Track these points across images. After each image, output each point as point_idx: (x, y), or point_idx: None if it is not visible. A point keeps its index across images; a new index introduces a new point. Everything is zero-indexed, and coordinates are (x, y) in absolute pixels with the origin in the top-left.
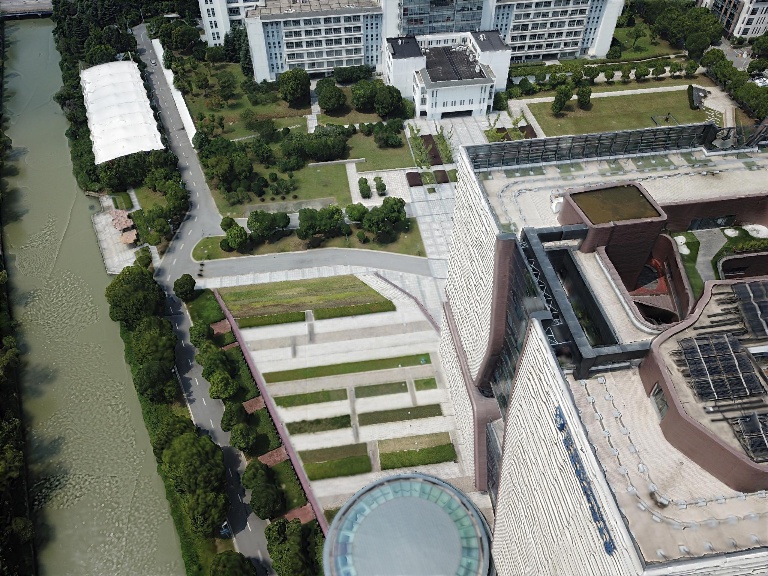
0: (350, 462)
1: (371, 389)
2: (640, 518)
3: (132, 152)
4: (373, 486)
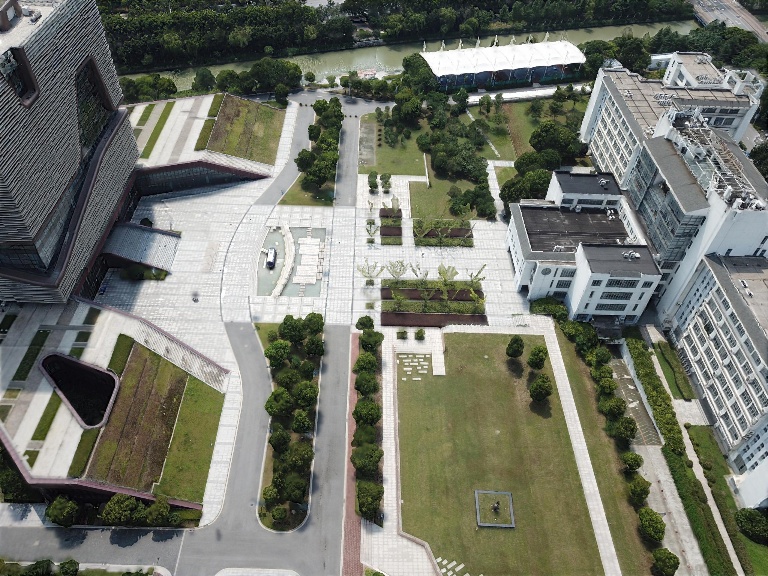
0: None
1: (136, 134)
2: None
3: (428, 61)
4: None
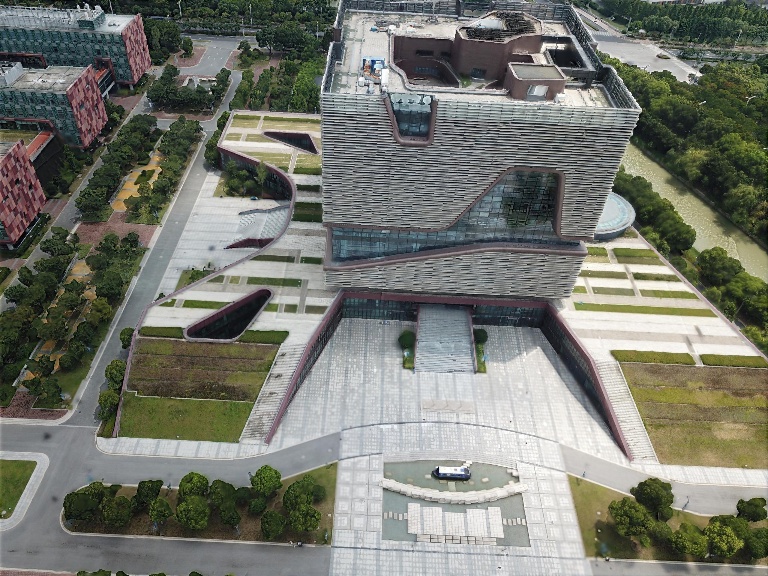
0: (628, 253)
1: (622, 292)
2: (556, 30)
3: None
4: (612, 230)
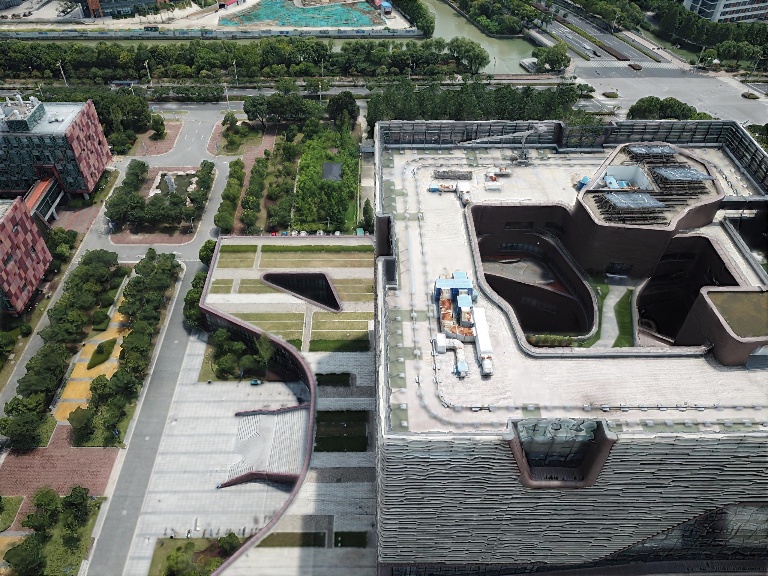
0: None
1: None
2: (715, 163)
3: None
4: None
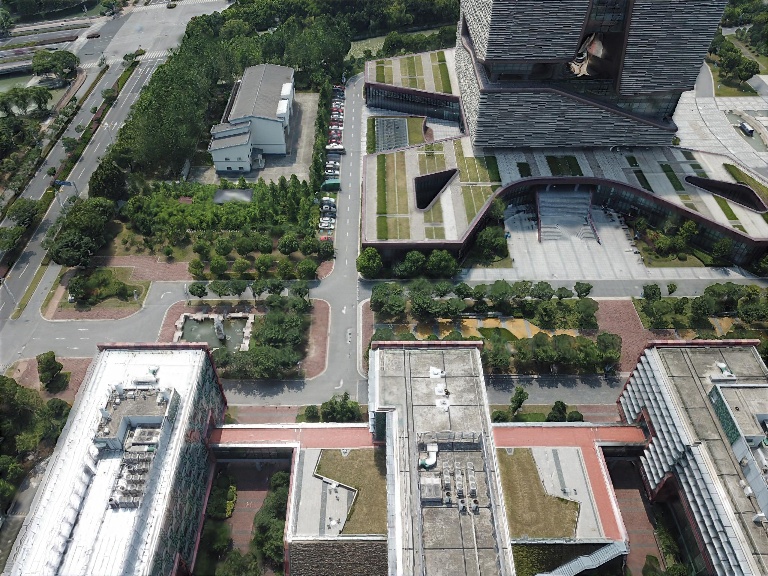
0: None
1: None
2: None
3: None
4: None
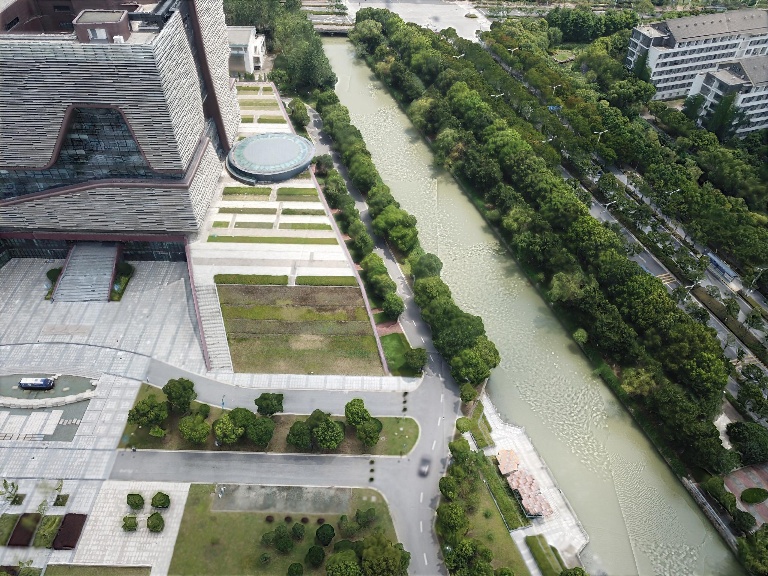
0: (289, 192)
1: (261, 226)
2: None
3: None
4: (280, 171)
